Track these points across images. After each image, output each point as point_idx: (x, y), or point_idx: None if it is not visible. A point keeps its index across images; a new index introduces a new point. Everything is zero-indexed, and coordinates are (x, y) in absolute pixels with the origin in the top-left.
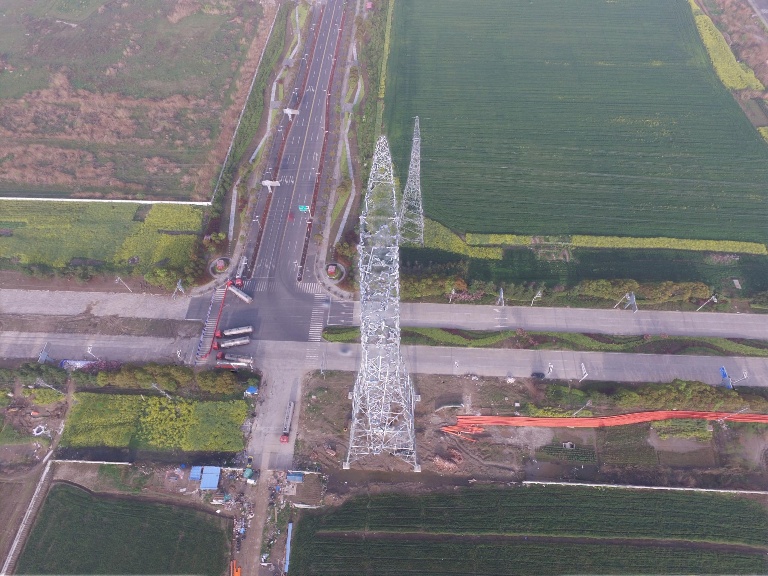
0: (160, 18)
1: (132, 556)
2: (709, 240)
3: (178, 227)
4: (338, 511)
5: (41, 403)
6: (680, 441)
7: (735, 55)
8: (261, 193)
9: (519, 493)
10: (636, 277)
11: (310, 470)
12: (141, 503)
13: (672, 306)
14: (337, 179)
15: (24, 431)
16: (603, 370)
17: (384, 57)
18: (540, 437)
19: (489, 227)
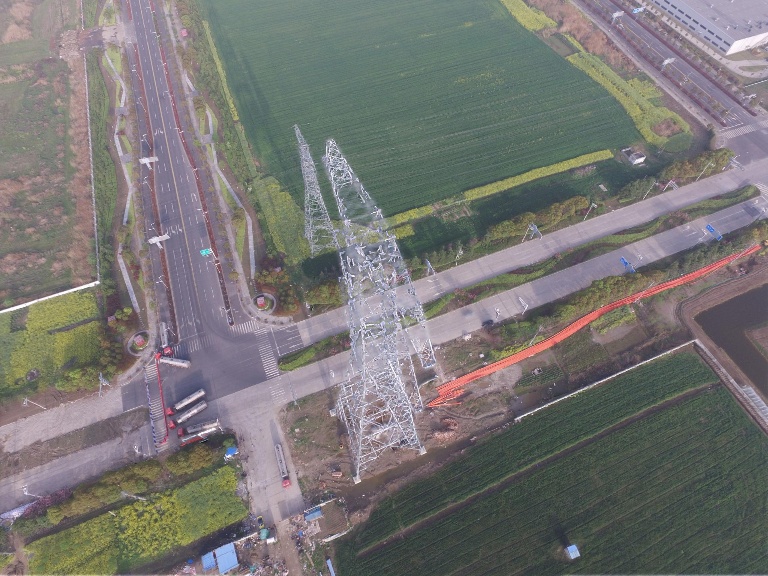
0: None
1: None
2: (569, 160)
3: (71, 320)
4: (368, 525)
5: None
6: (616, 330)
7: (525, 2)
8: (151, 253)
9: (516, 430)
10: (528, 209)
11: (324, 501)
12: None
13: (565, 223)
14: (226, 212)
15: None
16: (536, 297)
17: (222, 80)
18: (512, 375)
19: (391, 209)
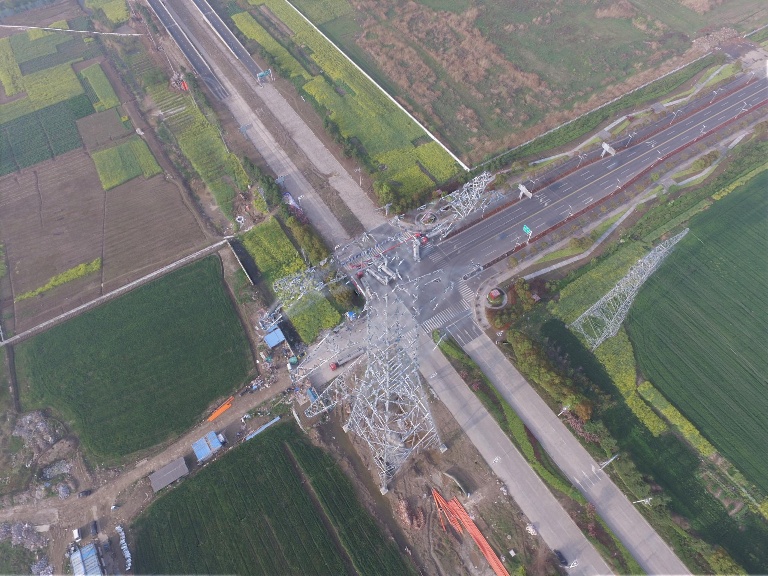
0: (591, 7)
1: (201, 332)
2: None
3: (431, 169)
4: (309, 447)
5: (255, 205)
6: None
7: None
8: (512, 193)
9: None
10: None
11: None
12: (234, 310)
13: None
14: (585, 232)
15: (235, 212)
16: None
17: (765, 165)
18: None
19: (680, 399)
